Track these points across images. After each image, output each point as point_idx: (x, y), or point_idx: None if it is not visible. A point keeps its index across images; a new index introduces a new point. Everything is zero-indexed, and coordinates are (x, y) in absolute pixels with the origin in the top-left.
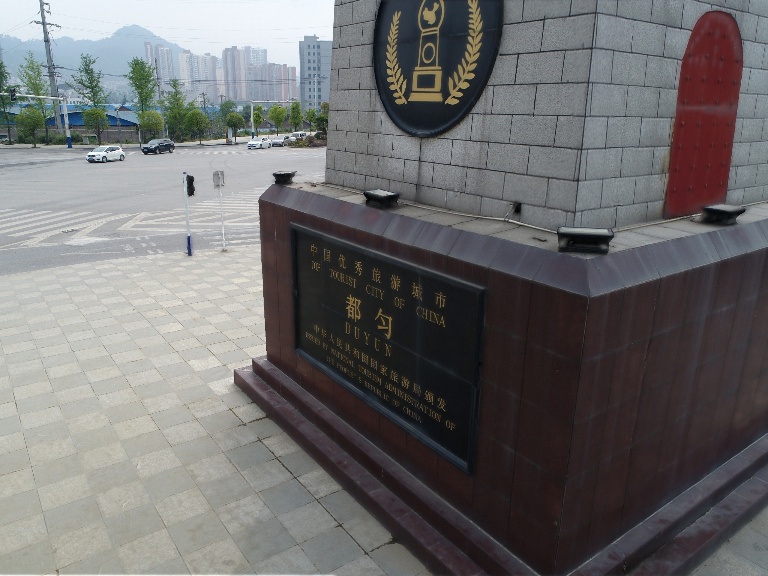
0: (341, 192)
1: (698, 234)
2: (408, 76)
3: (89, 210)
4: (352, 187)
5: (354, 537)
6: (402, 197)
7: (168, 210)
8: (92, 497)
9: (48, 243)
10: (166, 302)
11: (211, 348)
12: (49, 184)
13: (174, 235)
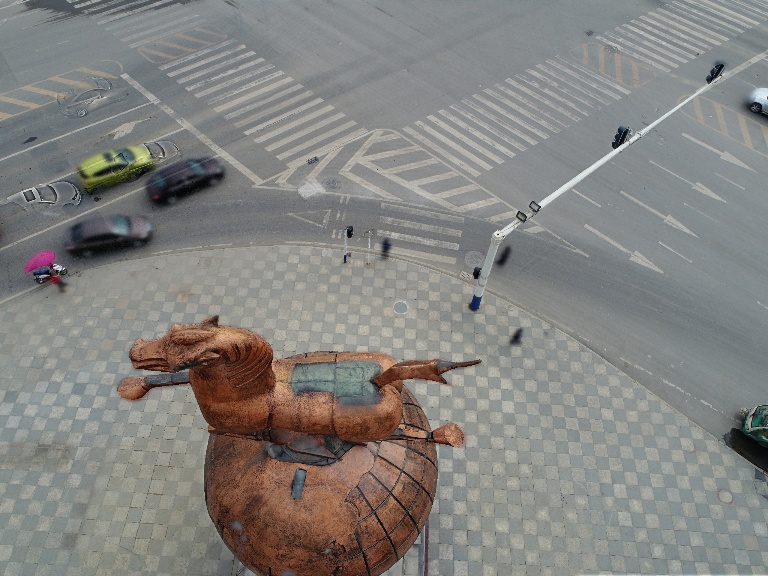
0: None
1: None
2: None
3: (346, 108)
4: None
5: (233, 568)
6: None
7: (398, 129)
8: (188, 497)
9: (290, 185)
10: (289, 343)
11: None
12: (355, 8)
13: (366, 202)
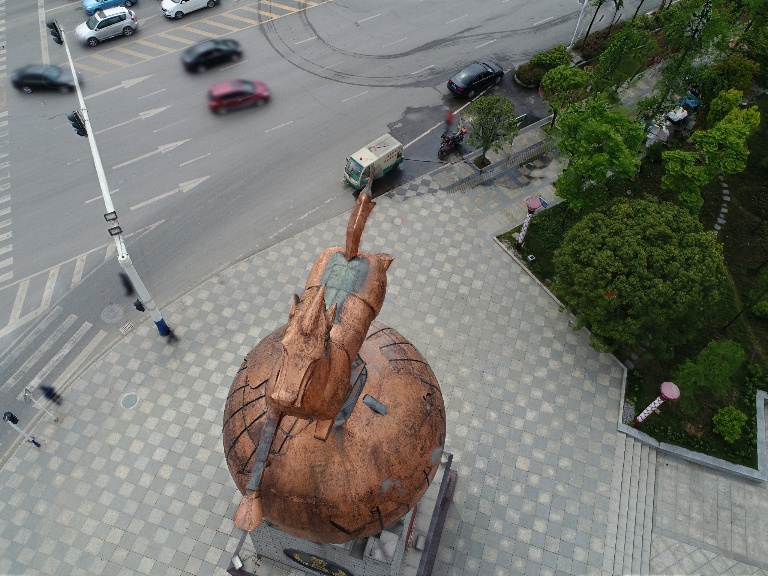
0: (280, 573)
1: (418, 569)
2: (309, 563)
3: None
4: (279, 562)
5: None
6: (313, 574)
7: None
8: None
9: None
10: (110, 537)
11: (189, 571)
12: None
13: None
